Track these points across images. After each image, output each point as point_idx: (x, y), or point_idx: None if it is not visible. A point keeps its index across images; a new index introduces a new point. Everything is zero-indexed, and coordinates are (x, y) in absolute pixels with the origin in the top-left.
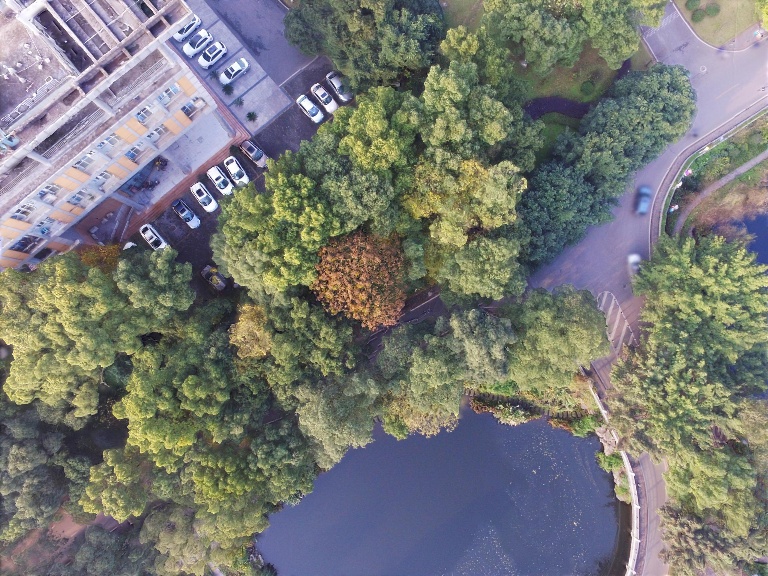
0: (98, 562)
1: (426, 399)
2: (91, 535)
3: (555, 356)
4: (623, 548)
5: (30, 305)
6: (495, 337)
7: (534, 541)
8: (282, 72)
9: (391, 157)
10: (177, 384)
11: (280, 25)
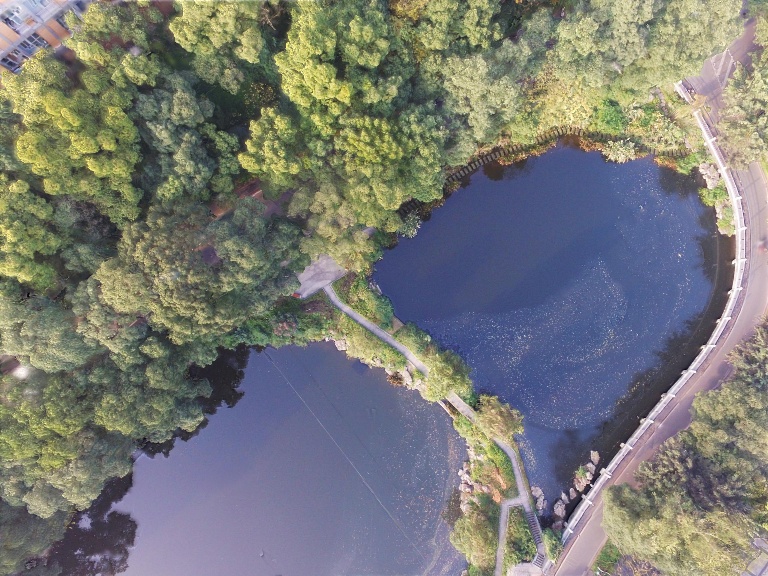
0: (257, 218)
1: (573, 66)
2: (247, 197)
3: (697, 24)
4: (725, 278)
5: None
6: None
7: (641, 271)
8: None
9: None
10: (342, 27)
11: None
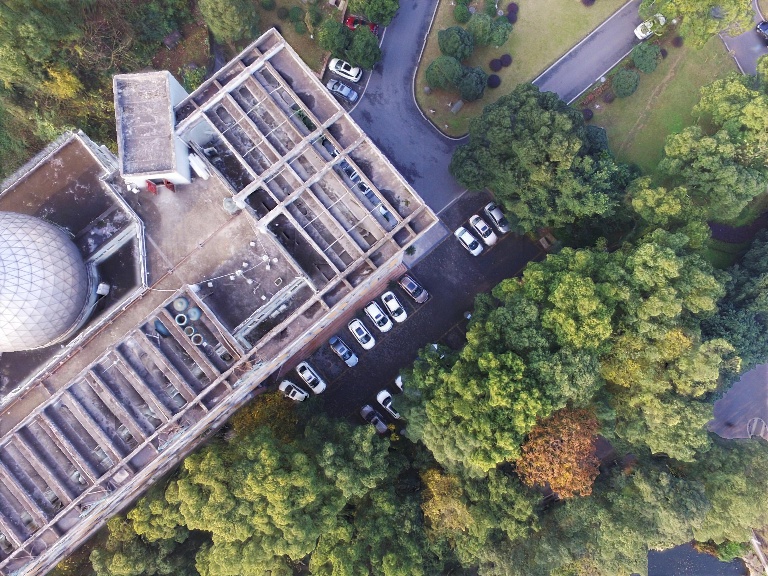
0: None
1: (616, 564)
2: None
3: (748, 521)
4: None
5: (237, 495)
6: (696, 509)
7: None
8: (438, 201)
9: (605, 337)
10: (375, 562)
11: (434, 151)
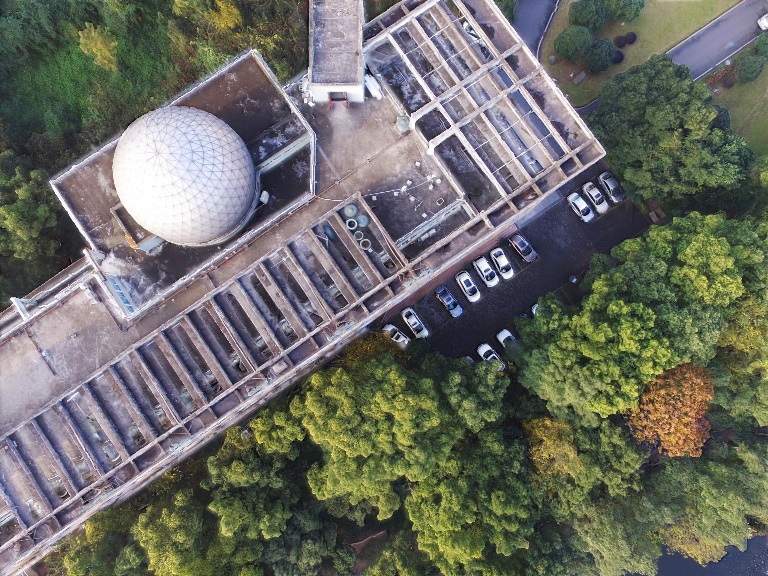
0: None
1: (716, 532)
2: None
3: None
4: None
5: (365, 411)
6: None
7: None
8: None
9: (737, 296)
10: (484, 498)
11: None
